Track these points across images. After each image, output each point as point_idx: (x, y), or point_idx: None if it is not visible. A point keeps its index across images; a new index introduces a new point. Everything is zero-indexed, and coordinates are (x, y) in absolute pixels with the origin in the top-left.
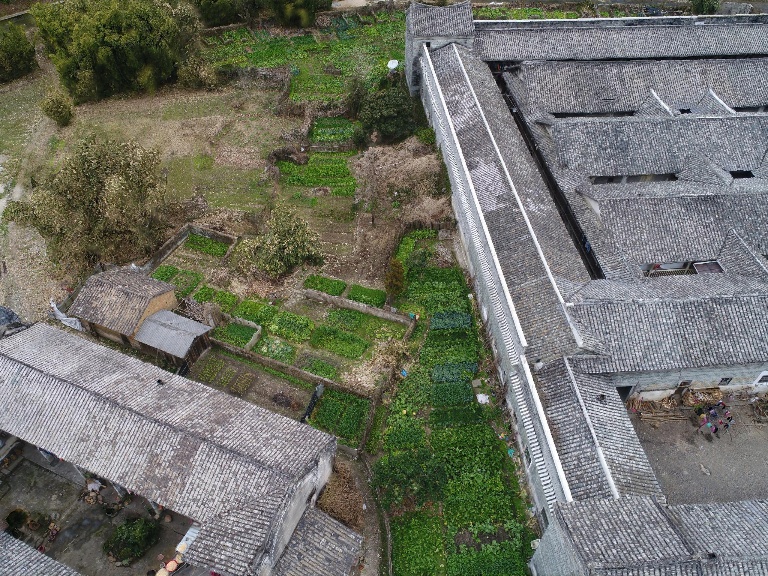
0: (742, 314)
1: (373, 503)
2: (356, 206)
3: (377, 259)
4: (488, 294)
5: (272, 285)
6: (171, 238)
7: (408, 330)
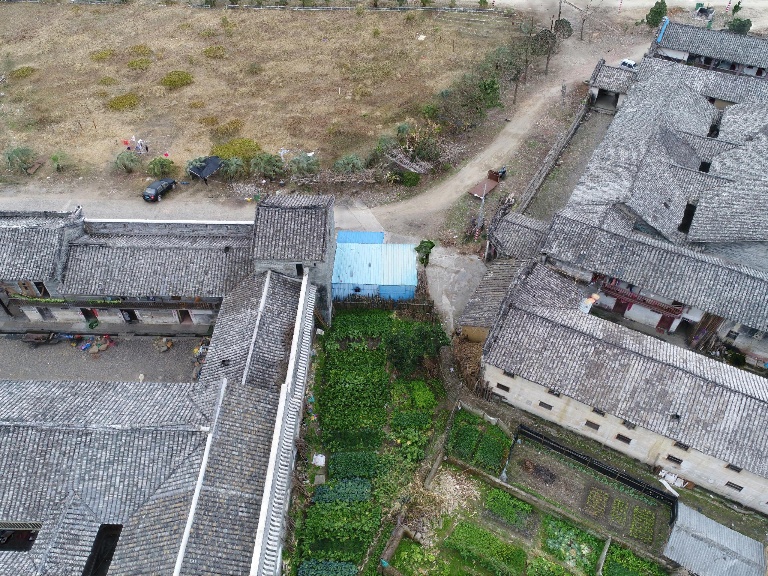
0: (5, 410)
1: None
2: None
3: None
4: None
5: None
6: None
7: (393, 546)
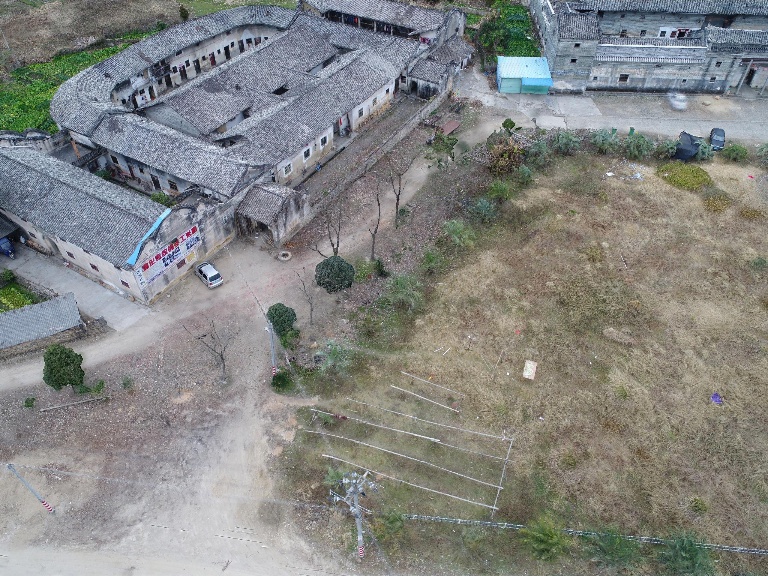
0: None
1: (478, 54)
2: None
3: (481, 2)
4: None
5: (430, 5)
6: None
7: None
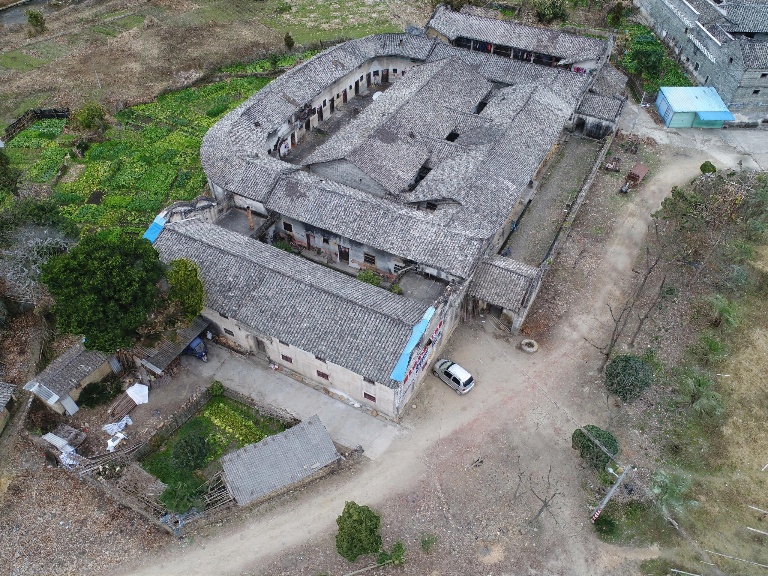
0: None
1: None
2: (576, 4)
3: (596, 22)
4: (669, 19)
5: (544, 26)
6: (484, 6)
7: None
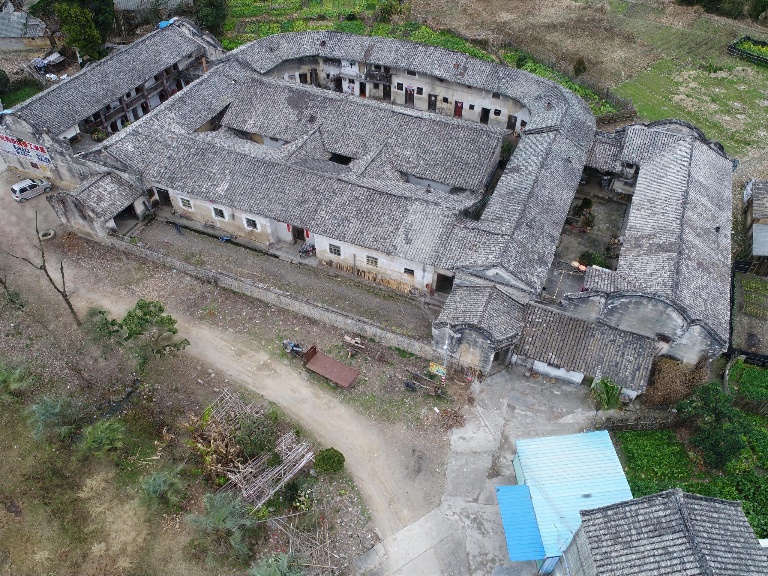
0: None
1: None
2: None
3: None
4: None
5: None
6: None
7: None
